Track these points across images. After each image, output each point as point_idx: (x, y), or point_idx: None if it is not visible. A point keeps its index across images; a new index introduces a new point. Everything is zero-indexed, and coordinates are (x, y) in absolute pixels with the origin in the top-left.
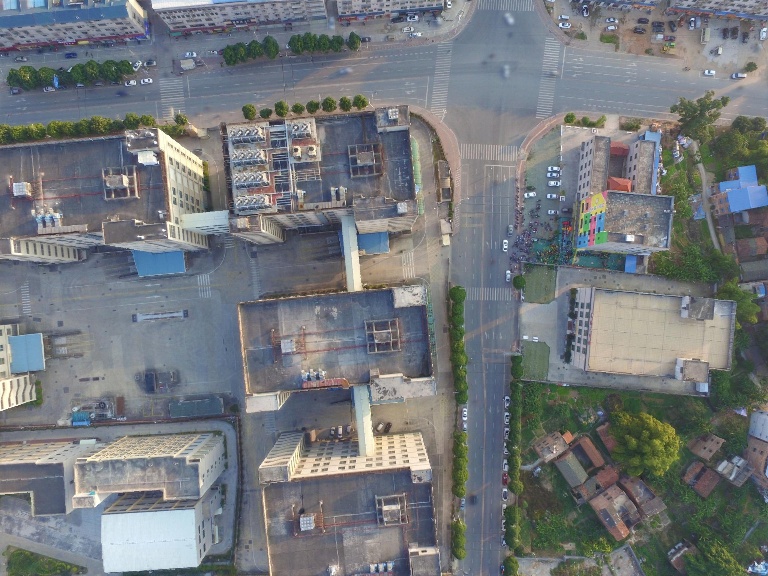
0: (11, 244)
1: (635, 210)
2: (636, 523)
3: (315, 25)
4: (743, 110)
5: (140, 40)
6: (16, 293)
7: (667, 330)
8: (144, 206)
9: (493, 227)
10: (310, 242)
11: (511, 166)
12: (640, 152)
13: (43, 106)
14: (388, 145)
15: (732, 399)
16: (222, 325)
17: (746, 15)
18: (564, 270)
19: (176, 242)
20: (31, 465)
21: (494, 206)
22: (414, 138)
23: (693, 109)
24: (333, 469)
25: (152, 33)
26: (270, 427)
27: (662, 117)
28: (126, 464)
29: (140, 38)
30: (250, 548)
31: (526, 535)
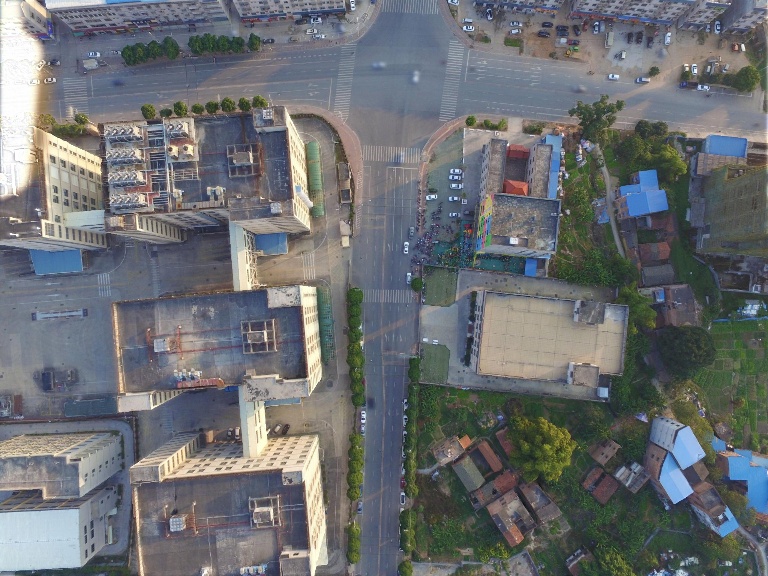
0: None
1: (522, 213)
2: (531, 529)
3: (219, 26)
4: (648, 114)
5: (44, 40)
6: None
7: (559, 334)
8: (23, 204)
9: (394, 229)
10: (211, 242)
11: (413, 168)
12: (537, 155)
13: None
14: (268, 145)
15: (632, 405)
16: None
17: (649, 20)
18: (465, 273)
19: (58, 240)
20: None
21: (396, 208)
22: (316, 139)
23: (588, 113)
24: (209, 470)
25: (57, 33)
26: (168, 427)
27: (566, 121)
28: (7, 462)
29: (44, 38)
30: None
31: (423, 540)
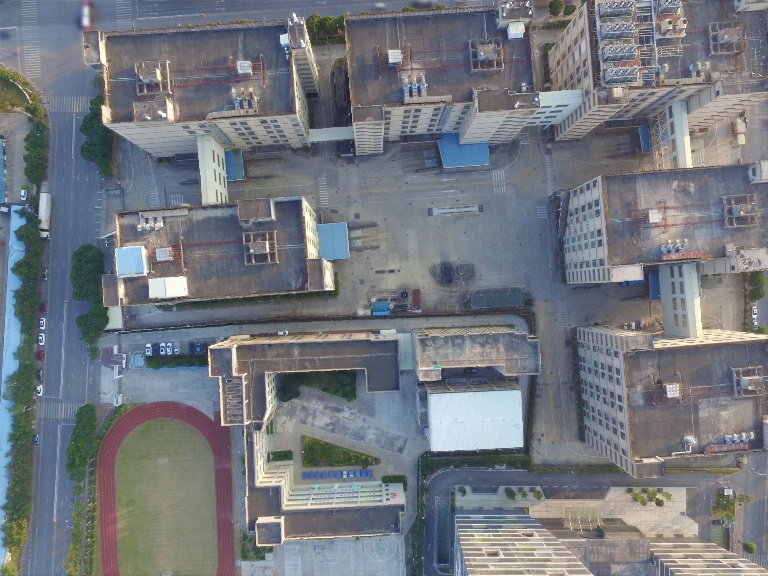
0: (383, 111)
1: None
2: None
3: None
4: None
5: None
6: (314, 185)
7: None
8: (506, 79)
9: None
10: (603, 140)
11: None
12: None
13: (343, 0)
14: (745, 25)
15: None
16: (516, 220)
17: None
18: None
19: (525, 119)
20: (364, 342)
21: None
22: None
23: None
24: (684, 343)
25: None
26: (563, 322)
27: None
28: (466, 340)
29: None
30: (542, 441)
31: None
